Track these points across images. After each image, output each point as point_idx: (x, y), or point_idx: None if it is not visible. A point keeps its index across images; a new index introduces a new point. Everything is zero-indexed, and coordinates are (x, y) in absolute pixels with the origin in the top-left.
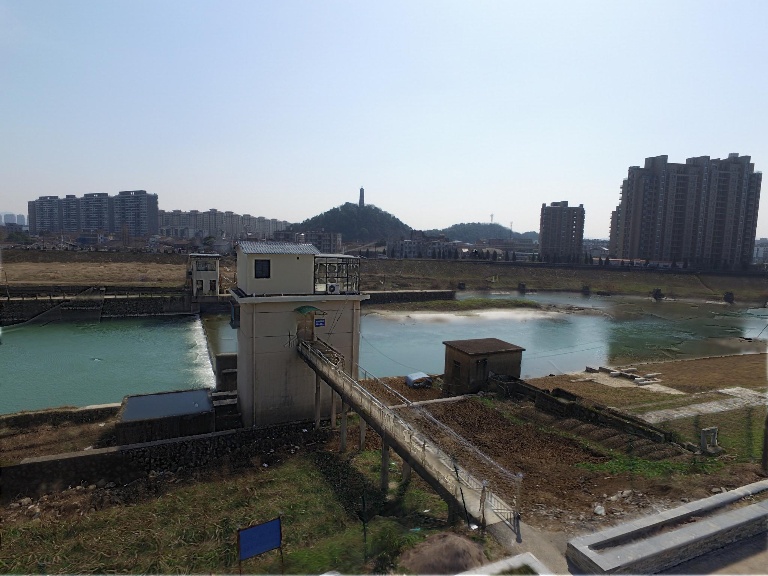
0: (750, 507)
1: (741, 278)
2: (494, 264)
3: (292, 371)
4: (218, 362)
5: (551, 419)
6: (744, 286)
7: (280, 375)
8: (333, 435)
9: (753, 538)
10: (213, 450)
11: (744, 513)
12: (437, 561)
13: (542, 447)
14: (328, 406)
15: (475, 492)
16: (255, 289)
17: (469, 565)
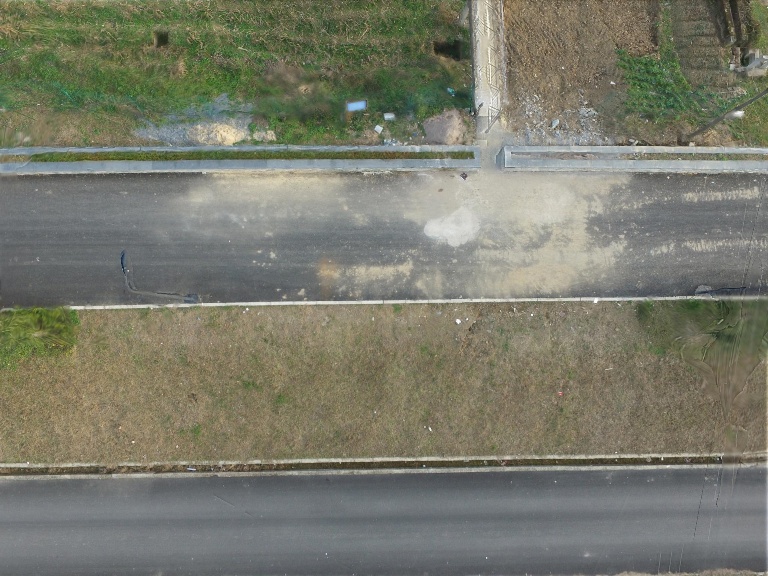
0: (627, 161)
1: None
2: None
3: None
4: None
5: None
6: None
7: None
8: None
9: (611, 173)
10: None
11: (617, 163)
12: (436, 134)
13: (627, 5)
14: None
15: (489, 88)
16: None
17: (449, 141)
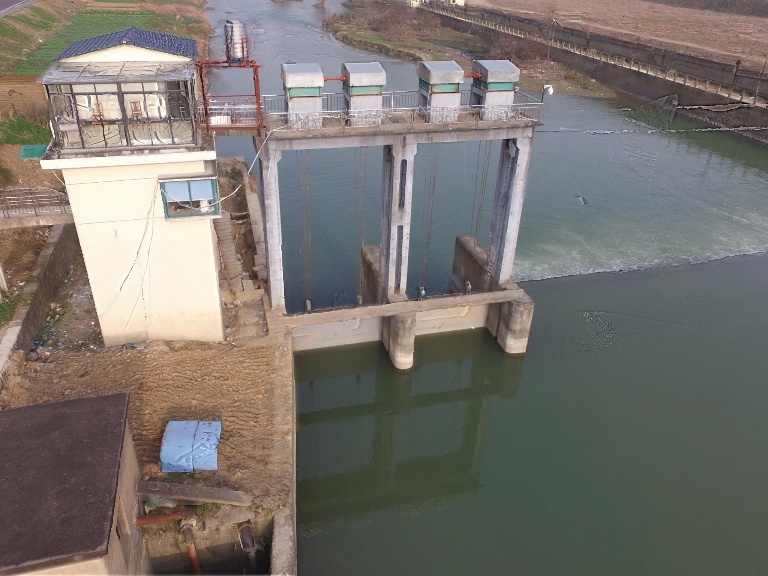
0: None
1: None
2: None
3: None
4: (456, 247)
5: None
6: None
7: None
8: None
9: None
10: None
11: None
12: None
13: None
14: None
15: None
16: None
17: None
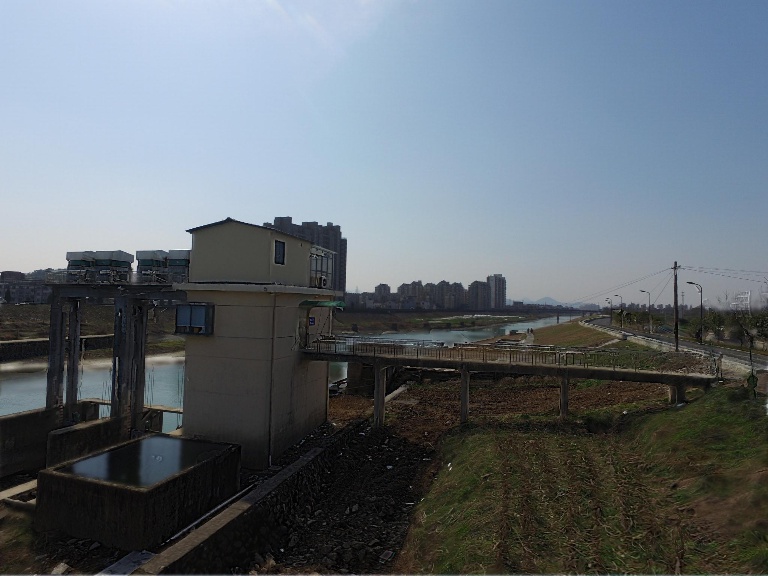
0: (724, 356)
1: (356, 314)
2: (158, 307)
3: (295, 380)
4: None
5: (493, 381)
6: (360, 319)
7: (288, 386)
8: (391, 429)
9: None
10: (318, 476)
11: None
12: None
13: None
14: (314, 419)
15: None
16: (275, 277)
17: None
